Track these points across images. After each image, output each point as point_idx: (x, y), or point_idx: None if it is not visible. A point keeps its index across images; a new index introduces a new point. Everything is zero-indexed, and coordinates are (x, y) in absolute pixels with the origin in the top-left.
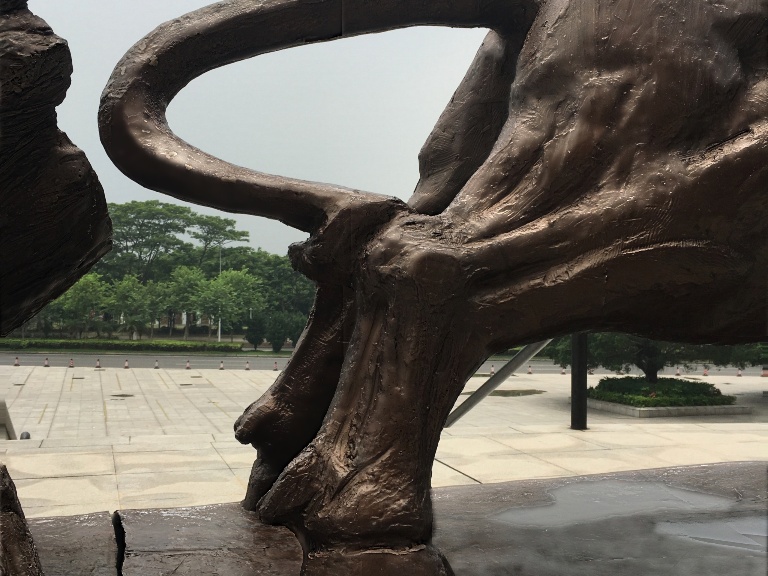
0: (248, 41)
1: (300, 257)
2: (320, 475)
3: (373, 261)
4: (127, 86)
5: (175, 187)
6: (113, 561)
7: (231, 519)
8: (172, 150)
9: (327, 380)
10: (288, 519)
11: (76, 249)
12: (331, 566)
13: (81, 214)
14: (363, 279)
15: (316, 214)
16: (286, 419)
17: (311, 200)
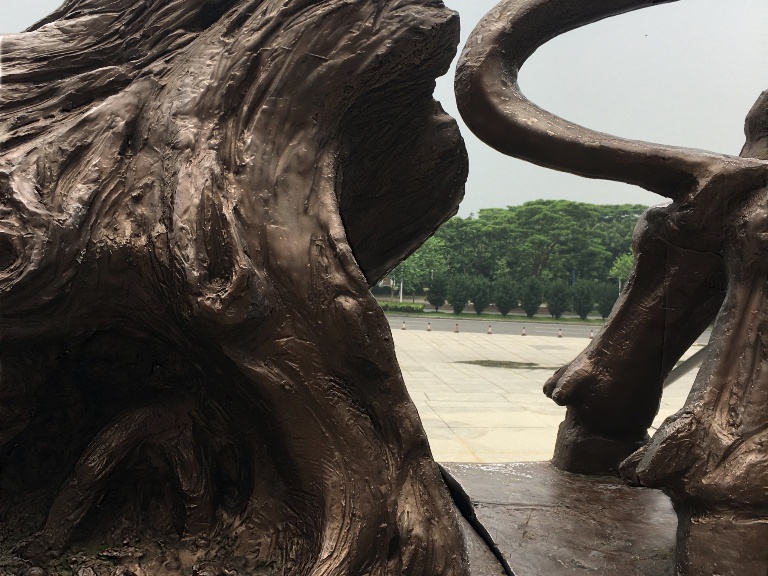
0: (597, 5)
1: (663, 223)
2: (701, 442)
3: (754, 228)
4: (485, 54)
5: (535, 153)
6: (457, 510)
7: (550, 478)
8: (532, 116)
9: (647, 346)
10: (667, 483)
11: (437, 213)
12: (720, 533)
13: (448, 180)
14: (741, 246)
15: (684, 179)
16: (605, 383)
17: (679, 165)
